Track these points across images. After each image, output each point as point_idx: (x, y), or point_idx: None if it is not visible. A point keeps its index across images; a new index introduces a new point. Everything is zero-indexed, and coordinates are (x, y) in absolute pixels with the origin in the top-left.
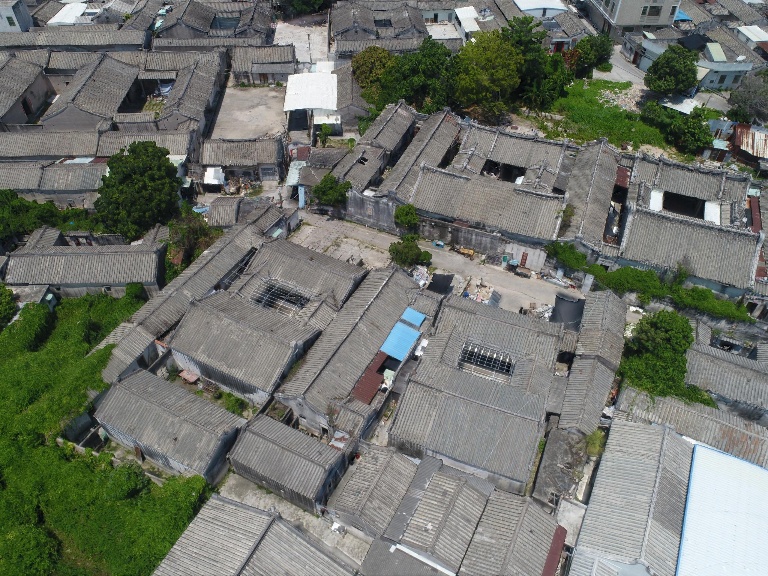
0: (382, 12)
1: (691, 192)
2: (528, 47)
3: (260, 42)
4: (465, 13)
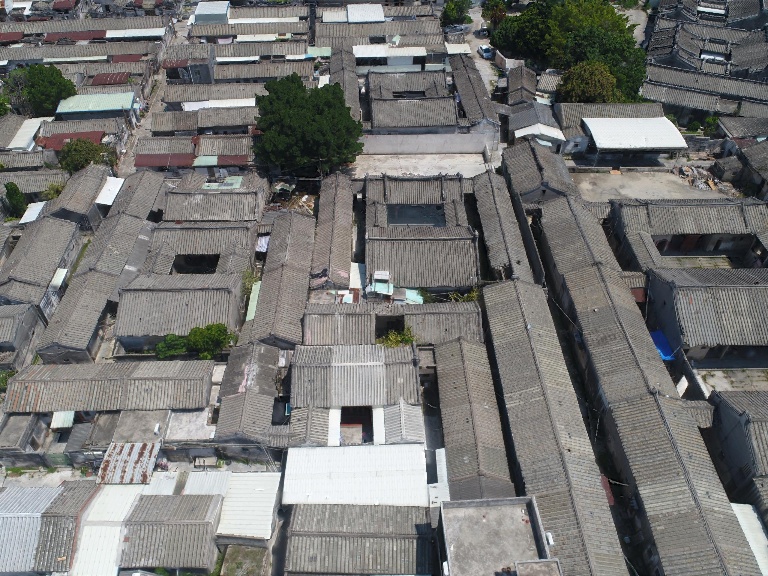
0: (382, 91)
1: (695, 8)
2: (574, 0)
3: (496, 175)
4: (372, 51)
